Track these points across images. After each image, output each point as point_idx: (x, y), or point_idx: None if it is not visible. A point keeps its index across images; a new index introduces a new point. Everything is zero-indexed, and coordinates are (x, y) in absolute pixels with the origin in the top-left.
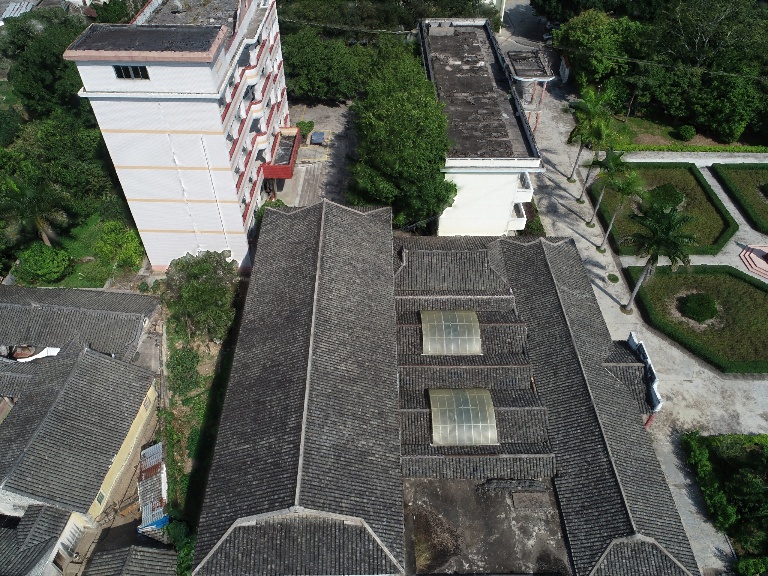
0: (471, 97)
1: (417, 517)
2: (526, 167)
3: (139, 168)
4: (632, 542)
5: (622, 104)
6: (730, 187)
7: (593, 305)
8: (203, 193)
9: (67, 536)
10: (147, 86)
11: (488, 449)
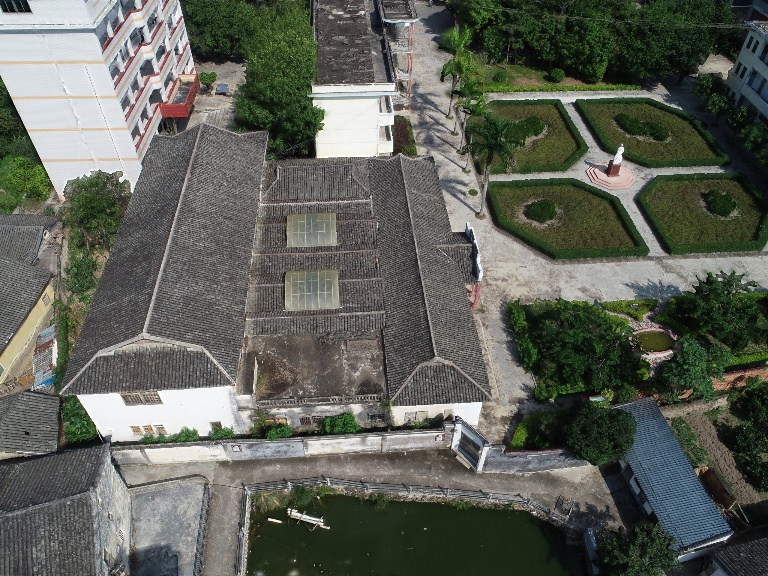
0: (347, 39)
1: (265, 362)
2: (383, 91)
3: (34, 98)
4: (434, 365)
5: (501, 52)
6: (587, 117)
7: (440, 205)
8: (95, 121)
9: None
10: (30, 19)
11: (331, 311)
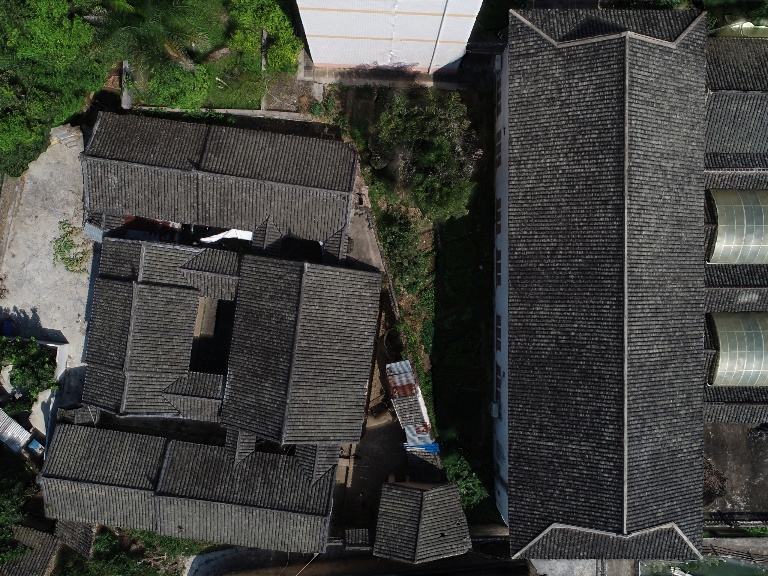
0: None
1: None
2: None
3: None
4: None
5: None
6: None
7: None
8: (426, 6)
9: None
10: None
11: None
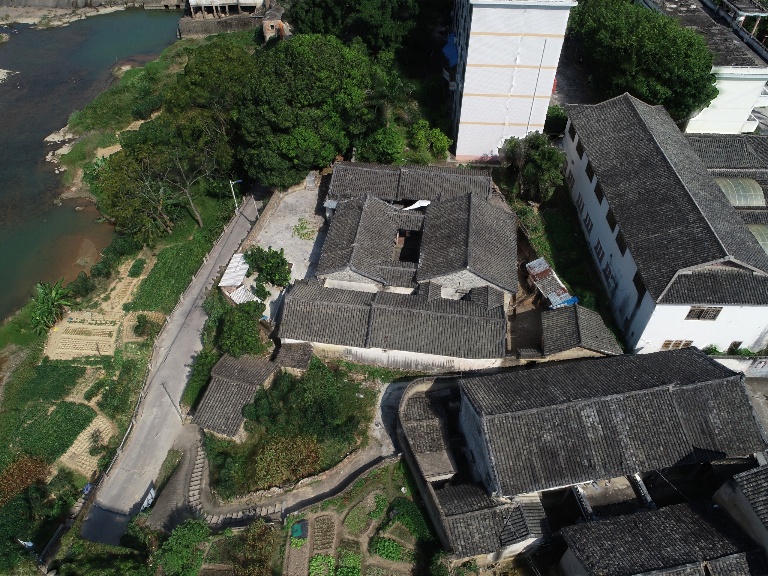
0: (700, 29)
1: None
2: None
3: (485, 66)
4: None
5: None
6: None
7: None
8: (526, 89)
9: None
10: None
11: None
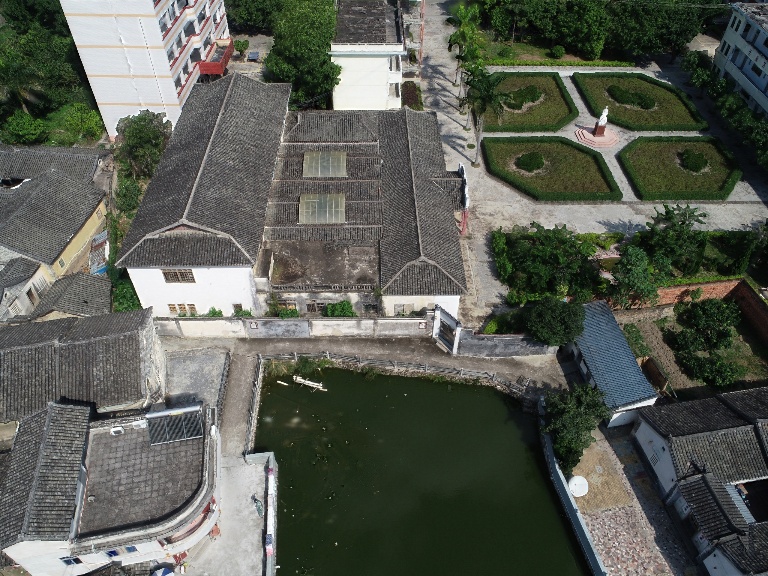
0: (365, 10)
1: (280, 259)
2: (393, 51)
3: (95, 47)
4: (420, 264)
5: (507, 30)
6: (581, 88)
7: (438, 149)
8: (145, 69)
9: (37, 281)
10: None
11: (337, 224)
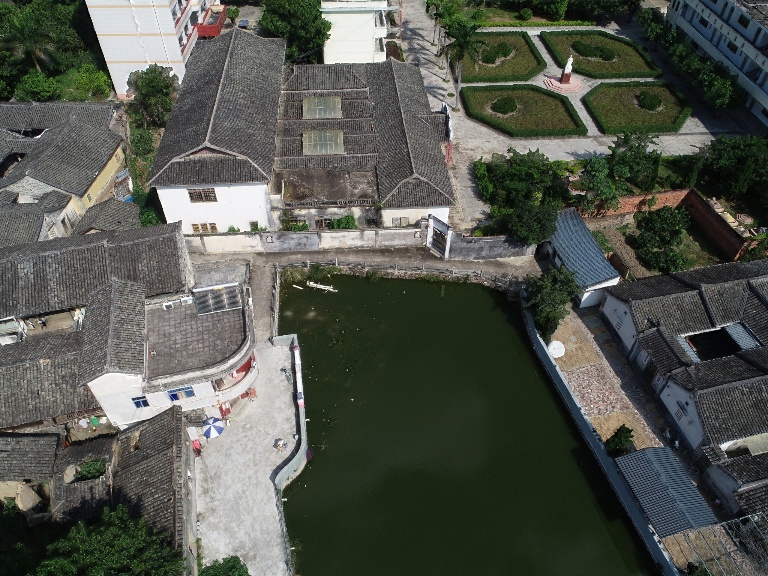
0: None
1: (289, 184)
2: (378, 7)
3: (105, 7)
4: (414, 181)
5: None
6: (548, 44)
7: (422, 93)
8: (151, 27)
9: (69, 212)
10: None
11: None
